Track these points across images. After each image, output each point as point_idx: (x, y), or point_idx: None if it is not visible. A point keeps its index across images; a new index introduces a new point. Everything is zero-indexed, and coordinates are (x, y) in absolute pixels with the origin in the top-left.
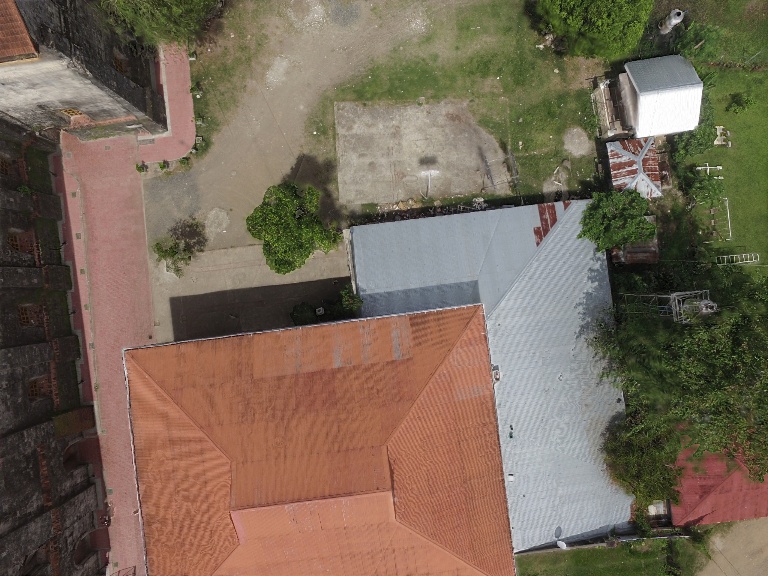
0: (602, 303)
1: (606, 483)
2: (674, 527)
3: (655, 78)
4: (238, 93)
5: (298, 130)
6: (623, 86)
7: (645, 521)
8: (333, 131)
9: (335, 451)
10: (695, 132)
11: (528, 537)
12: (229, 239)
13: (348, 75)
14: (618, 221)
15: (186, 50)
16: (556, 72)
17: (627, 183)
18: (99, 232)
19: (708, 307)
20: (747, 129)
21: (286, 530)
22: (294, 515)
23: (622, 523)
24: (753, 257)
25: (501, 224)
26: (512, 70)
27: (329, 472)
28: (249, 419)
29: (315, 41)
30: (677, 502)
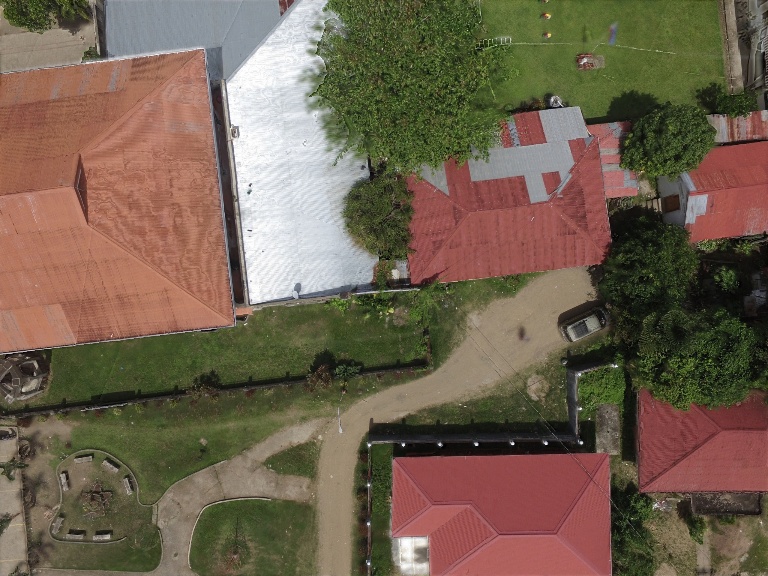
0: None
1: (348, 244)
2: (413, 286)
3: None
4: None
5: None
6: None
7: (383, 279)
8: None
9: (31, 160)
10: None
11: (266, 290)
12: (3, 26)
13: None
14: None
15: None
16: None
17: None
18: None
19: None
20: None
21: None
22: None
23: (365, 284)
24: (505, 40)
25: None
26: None
27: (20, 175)
28: None
29: None
30: (403, 250)
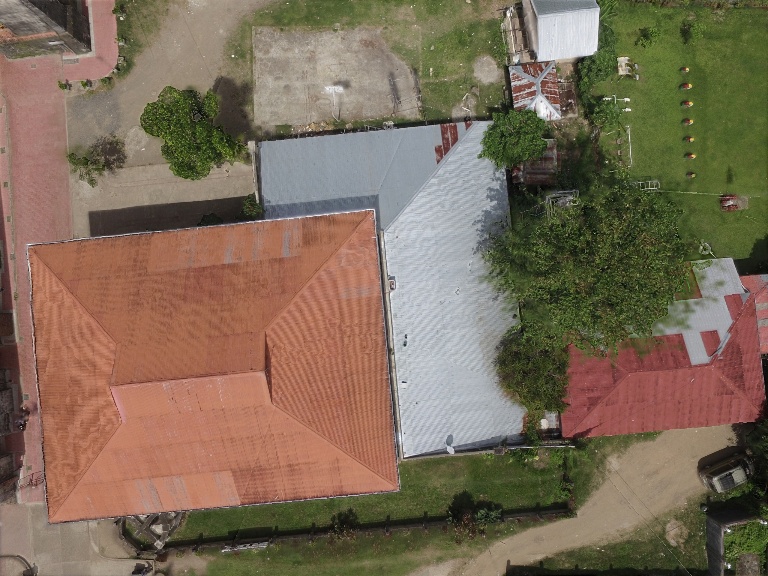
0: None
1: (499, 395)
2: (564, 439)
3: (554, 3)
4: (160, 16)
5: (217, 53)
6: (526, 12)
7: (535, 432)
8: (250, 54)
9: (216, 336)
10: (595, 58)
11: (420, 443)
12: (147, 156)
13: (267, 1)
14: (513, 138)
15: None
16: (468, 2)
17: (526, 105)
18: (23, 147)
19: (571, 201)
20: (655, 63)
21: (166, 409)
22: (172, 394)
23: (514, 435)
24: (654, 184)
25: (404, 142)
26: None
27: (208, 354)
28: (138, 307)
29: None
30: (562, 410)
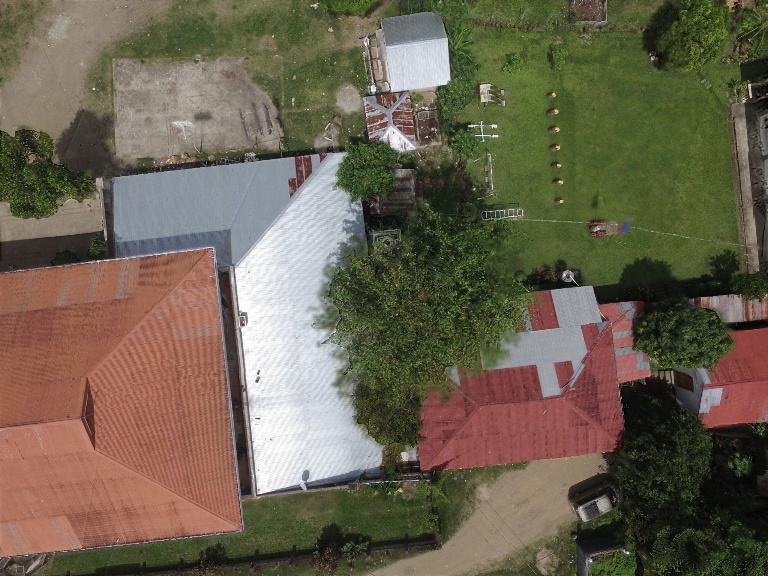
0: (358, 254)
1: (357, 429)
2: (422, 472)
3: (404, 33)
4: (20, 50)
5: (78, 86)
6: (379, 42)
7: (392, 466)
8: (111, 87)
9: (37, 382)
10: (449, 87)
11: (274, 479)
12: None
13: (128, 33)
14: (362, 171)
15: None
16: (330, 31)
17: (380, 136)
18: None
19: (384, 242)
20: (522, 89)
21: None
22: None
23: (373, 468)
24: (517, 212)
25: (258, 176)
26: (287, 29)
27: (27, 402)
28: None
29: None
30: (413, 445)
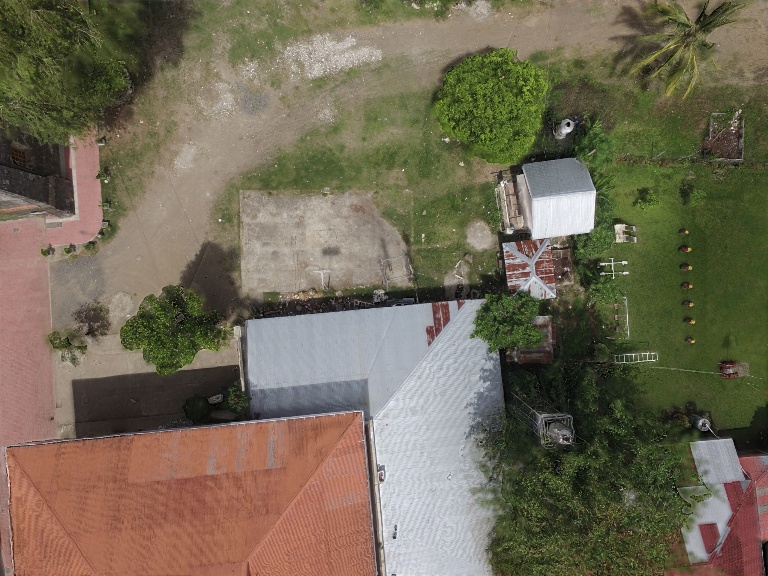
0: (494, 402)
1: None
2: None
3: (549, 182)
4: (146, 179)
5: (204, 217)
6: (520, 187)
7: None
8: (238, 219)
9: (197, 565)
10: (591, 235)
11: None
12: None
13: (255, 163)
14: (506, 326)
15: (96, 135)
16: (461, 165)
17: (520, 285)
18: (5, 313)
19: (564, 439)
20: (654, 225)
21: None
22: None
23: None
24: (652, 357)
25: (394, 322)
26: (417, 162)
27: None
28: (118, 527)
29: (223, 129)
30: None
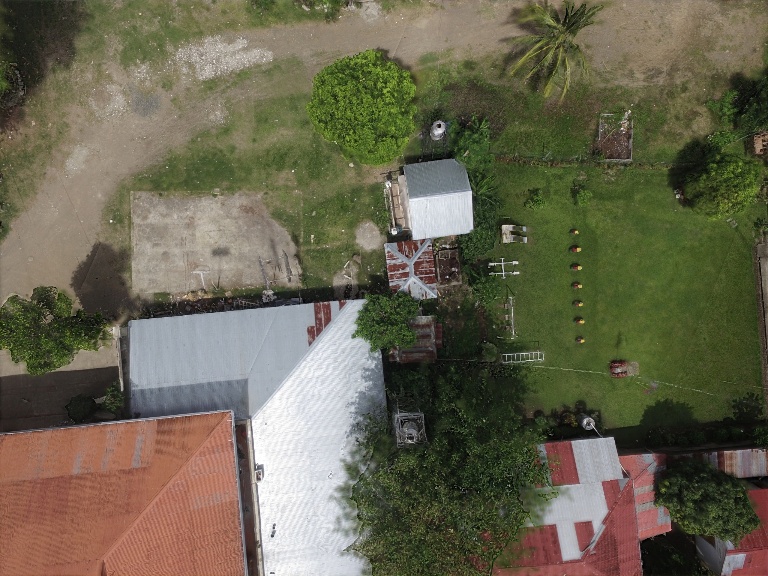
0: (376, 402)
1: None
2: None
3: (427, 183)
4: (37, 180)
5: (95, 218)
6: (401, 188)
7: None
8: (129, 220)
9: (53, 564)
10: (471, 235)
11: None
12: None
13: (146, 165)
14: (382, 326)
15: None
16: (351, 166)
17: (400, 285)
18: None
19: (408, 438)
20: (544, 225)
21: None
22: None
23: None
24: (538, 356)
25: (276, 322)
26: (307, 163)
27: None
28: None
29: (115, 130)
30: None
